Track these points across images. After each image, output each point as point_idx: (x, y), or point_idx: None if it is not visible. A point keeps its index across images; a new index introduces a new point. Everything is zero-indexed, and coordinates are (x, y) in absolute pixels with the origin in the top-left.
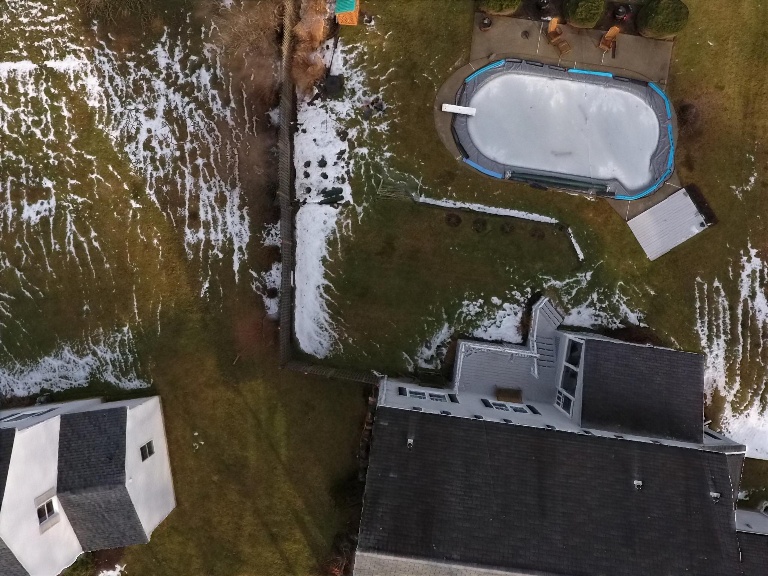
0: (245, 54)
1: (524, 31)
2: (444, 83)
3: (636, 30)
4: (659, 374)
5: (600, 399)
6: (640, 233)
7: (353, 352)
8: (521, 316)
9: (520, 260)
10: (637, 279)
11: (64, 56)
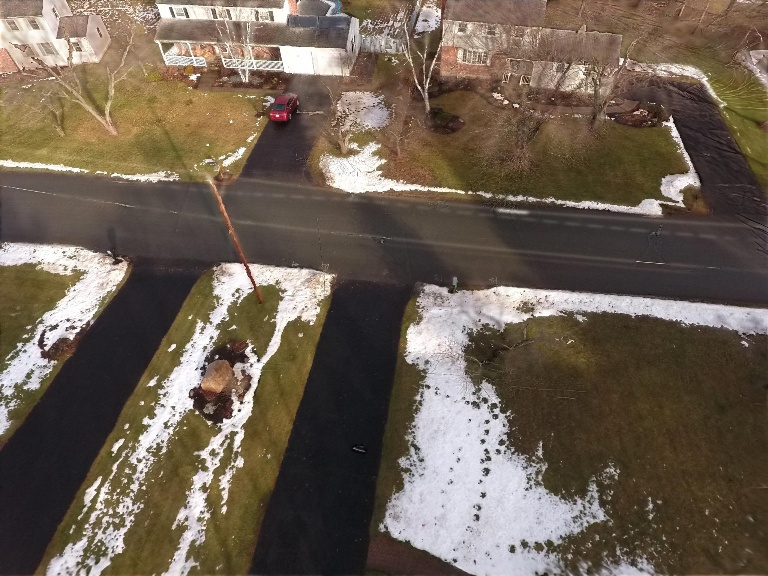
0: None
1: None
2: None
3: None
4: None
5: None
6: None
7: None
8: None
9: None
10: None
11: (124, 7)
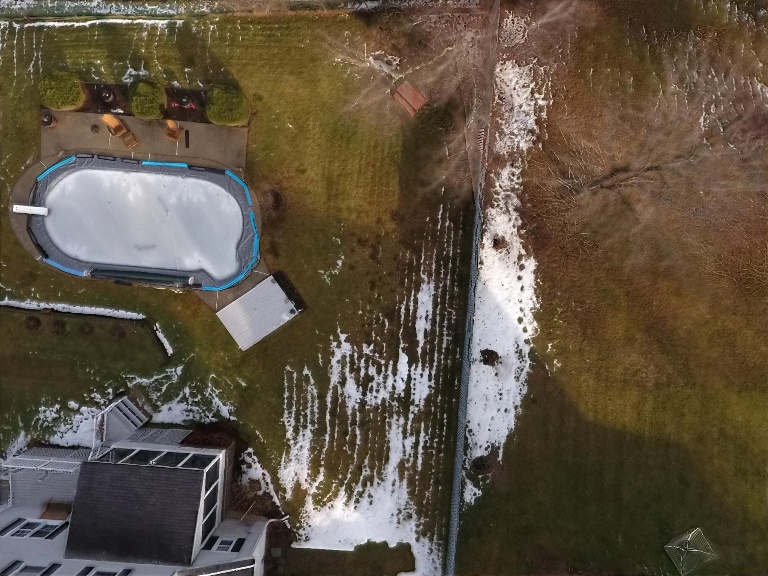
0: None
1: (94, 125)
2: (17, 183)
3: None
4: (154, 494)
5: (88, 526)
6: (230, 324)
7: None
8: (100, 419)
9: (100, 361)
10: (228, 371)
11: None
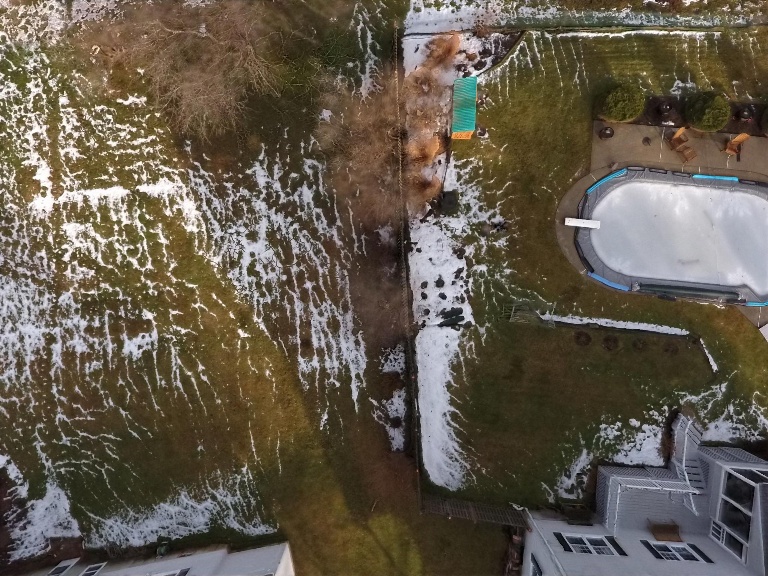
0: (348, 169)
1: (645, 137)
2: (565, 195)
3: (761, 131)
4: None
5: None
6: None
7: (487, 483)
8: (661, 437)
9: (655, 377)
10: None
11: (157, 180)
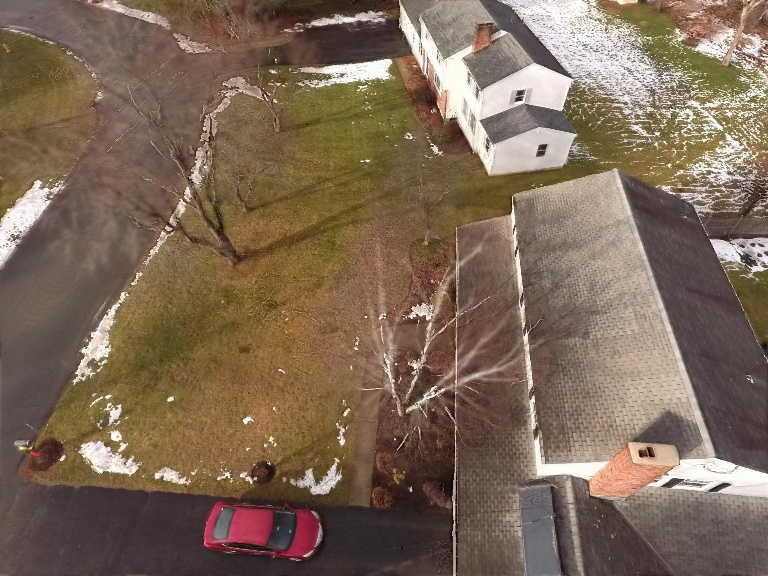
0: None
1: None
2: None
3: None
4: None
5: None
6: None
7: None
8: None
9: None
10: None
11: (736, 140)
